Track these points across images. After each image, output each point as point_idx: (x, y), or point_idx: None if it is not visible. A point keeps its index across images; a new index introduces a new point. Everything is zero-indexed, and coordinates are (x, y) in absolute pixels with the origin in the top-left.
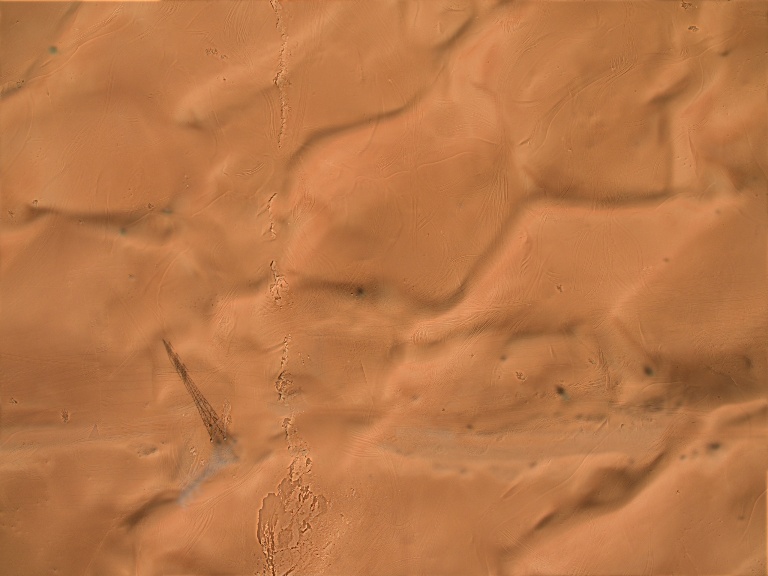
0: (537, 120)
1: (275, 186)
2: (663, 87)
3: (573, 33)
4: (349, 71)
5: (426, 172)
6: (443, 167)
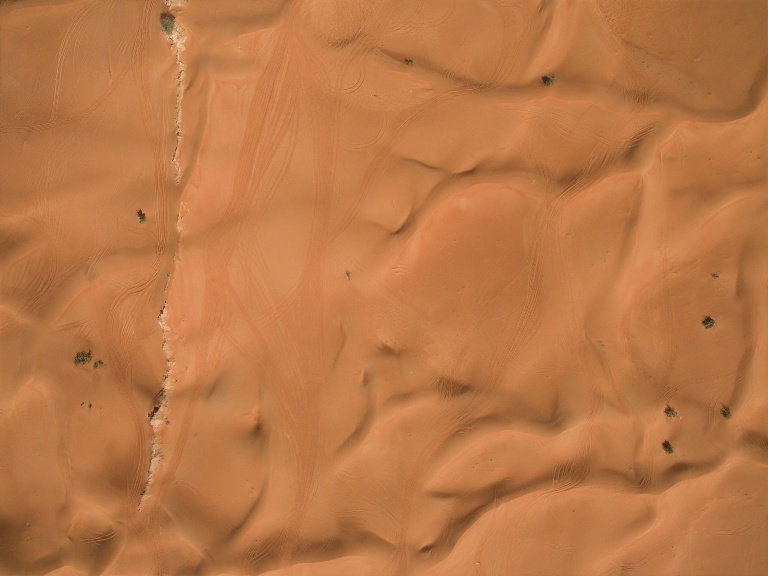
0: (448, 524)
1: (122, 567)
2: (607, 516)
3: (520, 423)
4: (243, 414)
5: (302, 569)
6: (323, 568)
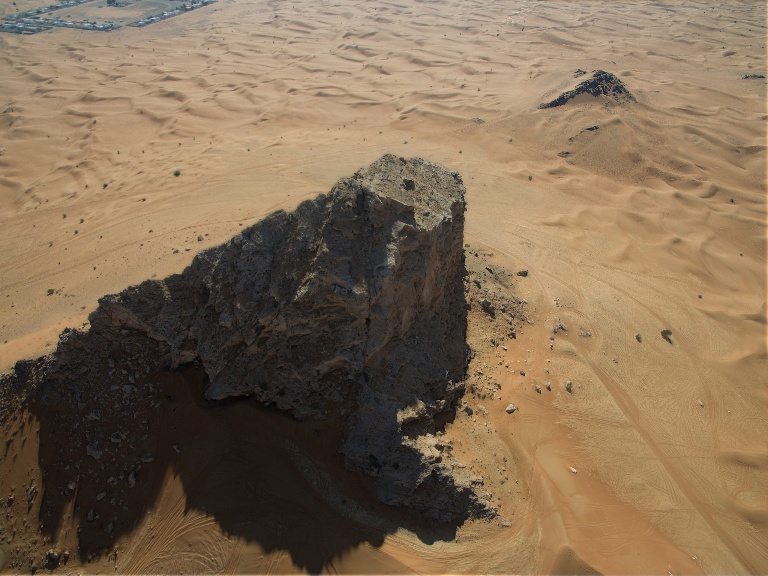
0: None
1: None
2: None
3: None
4: None
5: None
6: None
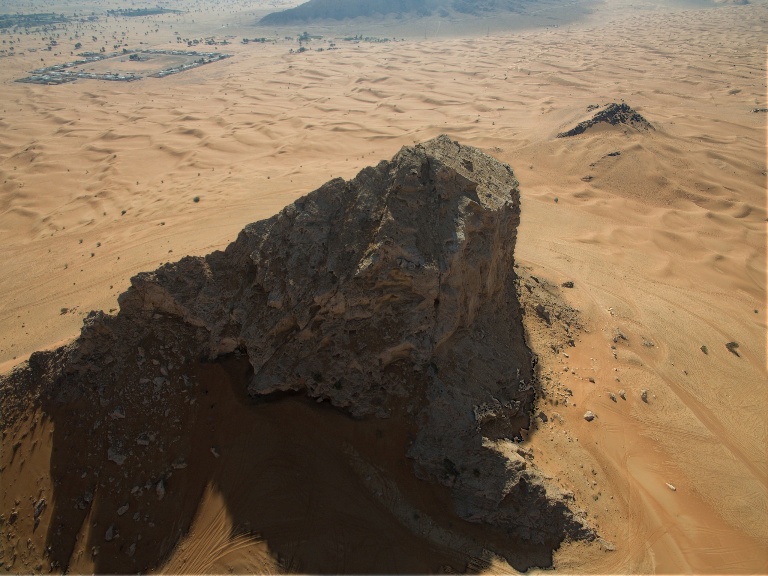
0: None
1: None
2: None
3: None
4: None
5: None
6: None
